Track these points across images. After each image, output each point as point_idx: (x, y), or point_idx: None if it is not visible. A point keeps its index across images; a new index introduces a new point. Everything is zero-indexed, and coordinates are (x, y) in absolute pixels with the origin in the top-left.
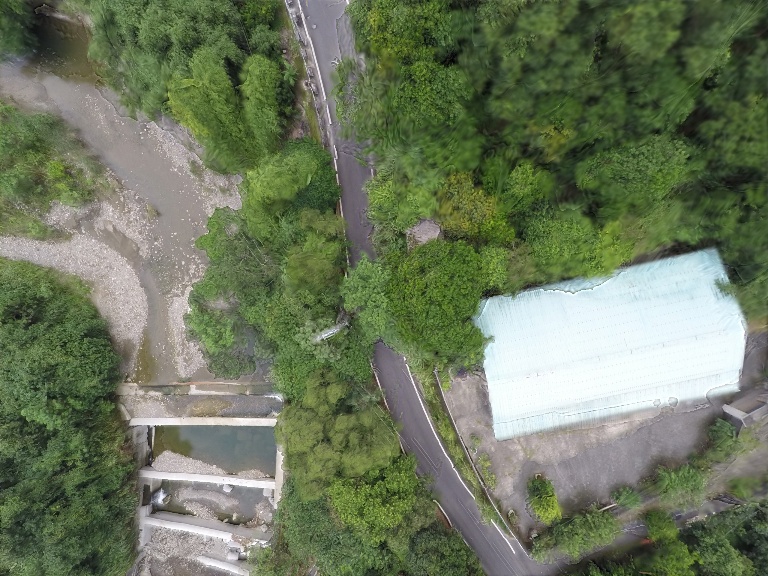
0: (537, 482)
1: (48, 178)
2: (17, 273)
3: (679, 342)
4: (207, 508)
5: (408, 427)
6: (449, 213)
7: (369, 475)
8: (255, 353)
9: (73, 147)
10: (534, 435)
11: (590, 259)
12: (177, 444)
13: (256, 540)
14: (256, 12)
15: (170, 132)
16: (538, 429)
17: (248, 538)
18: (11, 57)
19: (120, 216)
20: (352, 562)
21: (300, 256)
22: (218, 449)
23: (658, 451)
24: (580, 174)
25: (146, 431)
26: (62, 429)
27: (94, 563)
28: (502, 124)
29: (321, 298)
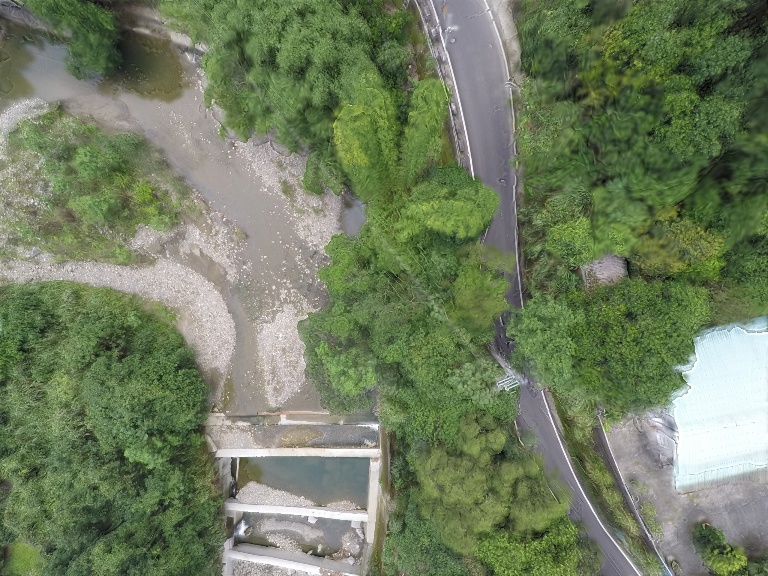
0: (706, 533)
1: (133, 201)
2: (102, 301)
3: None
4: (290, 540)
5: (549, 469)
6: (672, 254)
7: None
8: (379, 390)
9: (158, 168)
10: None
11: None
12: (262, 475)
13: (345, 574)
14: (385, 25)
15: (331, 163)
16: (725, 481)
17: (337, 572)
18: (100, 75)
19: (207, 239)
20: None
21: (471, 297)
22: (305, 480)
23: None
24: None
25: (230, 461)
26: None
27: None
28: None
29: (474, 337)
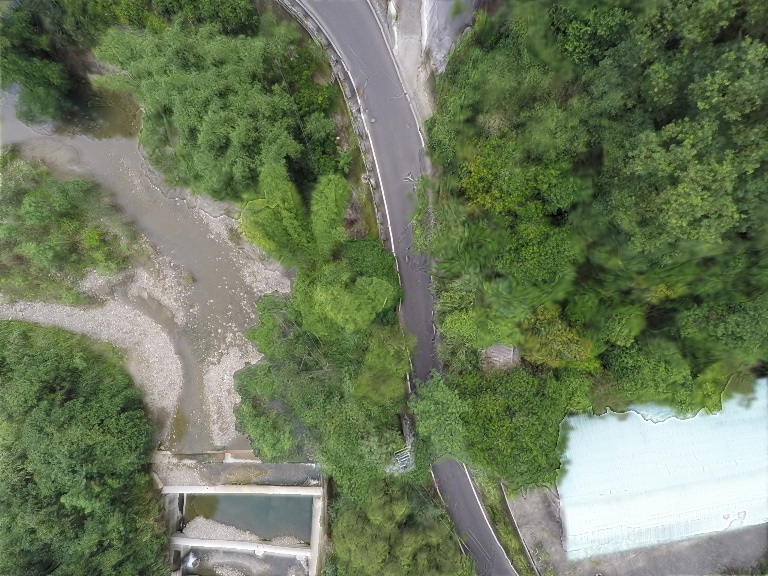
0: None
1: (81, 246)
2: (49, 343)
3: (752, 460)
4: (238, 571)
5: (463, 519)
6: (536, 350)
7: None
8: (306, 442)
9: (107, 213)
10: None
11: (680, 401)
12: (209, 510)
13: None
14: (312, 102)
15: None
16: (606, 540)
17: None
18: (47, 127)
19: (155, 283)
20: None
21: (371, 373)
22: (251, 514)
23: (719, 552)
24: (675, 322)
25: (177, 496)
26: None
27: None
28: (607, 286)
29: None
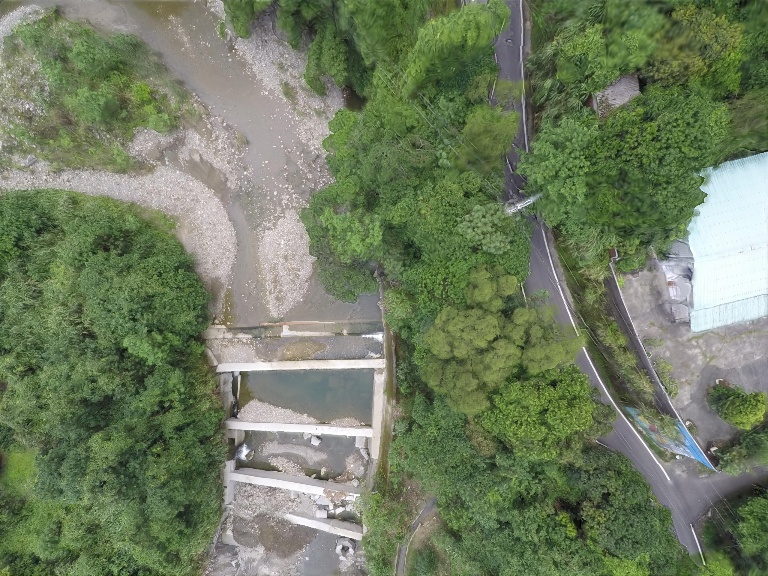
0: (720, 387)
1: (132, 103)
2: (100, 206)
3: None
4: (293, 463)
5: None
6: (688, 42)
7: (544, 378)
8: (385, 266)
9: (157, 70)
10: (715, 335)
11: None
12: (264, 393)
13: (350, 494)
14: None
15: None
16: (740, 317)
17: (341, 492)
18: None
19: (207, 144)
20: (505, 487)
21: None
22: (308, 397)
23: None
24: None
25: (231, 380)
26: (157, 368)
27: (185, 518)
28: None
29: (483, 185)
